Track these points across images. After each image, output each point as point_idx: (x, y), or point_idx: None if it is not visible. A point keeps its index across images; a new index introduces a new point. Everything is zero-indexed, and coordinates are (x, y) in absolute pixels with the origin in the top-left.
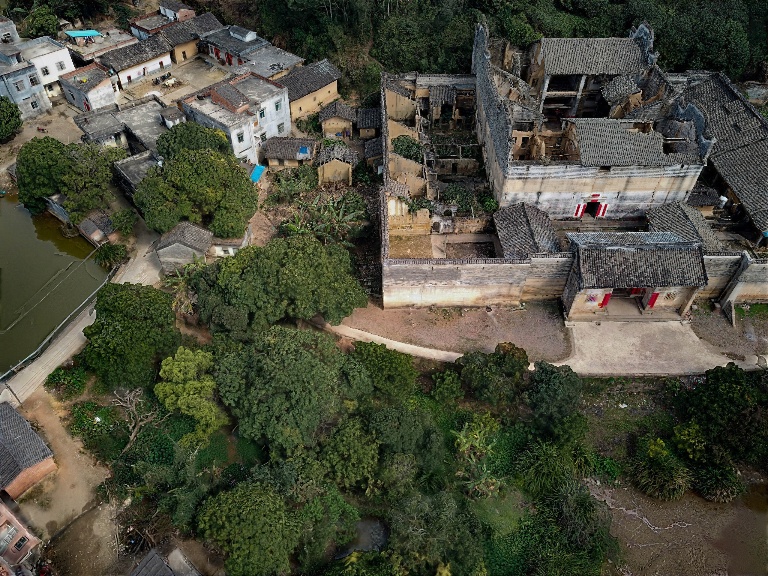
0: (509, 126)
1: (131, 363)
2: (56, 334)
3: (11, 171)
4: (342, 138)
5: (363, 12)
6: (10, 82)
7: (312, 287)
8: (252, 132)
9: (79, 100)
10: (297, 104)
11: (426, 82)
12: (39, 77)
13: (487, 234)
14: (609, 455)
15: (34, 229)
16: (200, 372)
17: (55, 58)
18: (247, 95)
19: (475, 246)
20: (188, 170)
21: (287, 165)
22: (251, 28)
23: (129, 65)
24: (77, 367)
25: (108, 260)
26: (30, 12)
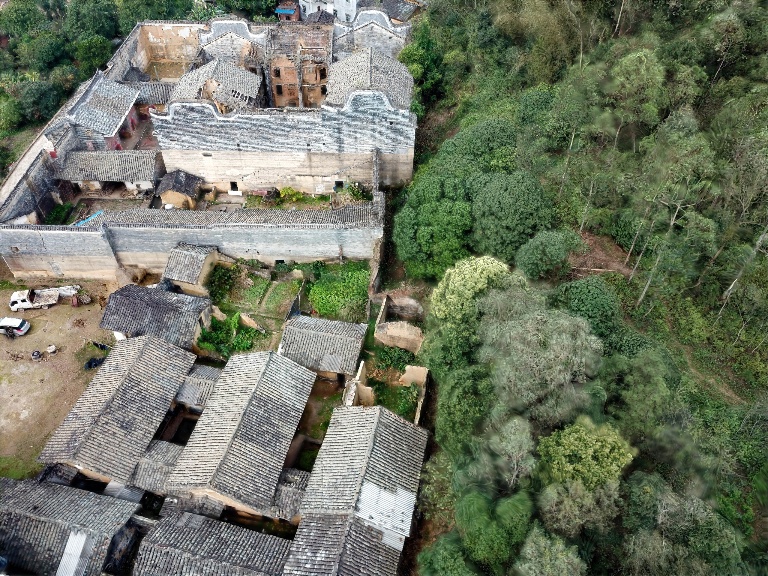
0: None
1: None
2: None
3: None
4: None
5: None
6: None
7: (128, 4)
8: None
9: None
10: None
11: None
12: None
13: None
14: (4, 140)
15: None
16: None
17: None
18: None
19: None
20: None
21: None
22: None
23: None
24: None
25: None
26: None
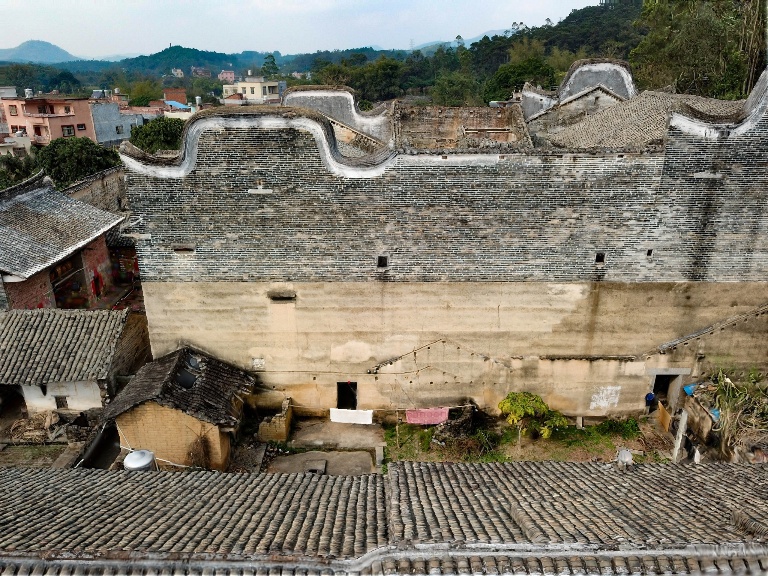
0: None
1: None
2: None
3: None
4: None
5: None
6: None
7: None
8: None
9: None
10: None
11: None
12: None
13: None
14: None
15: None
16: None
17: None
18: None
19: None
20: None
21: None
22: None
23: None
24: None
25: None
26: None
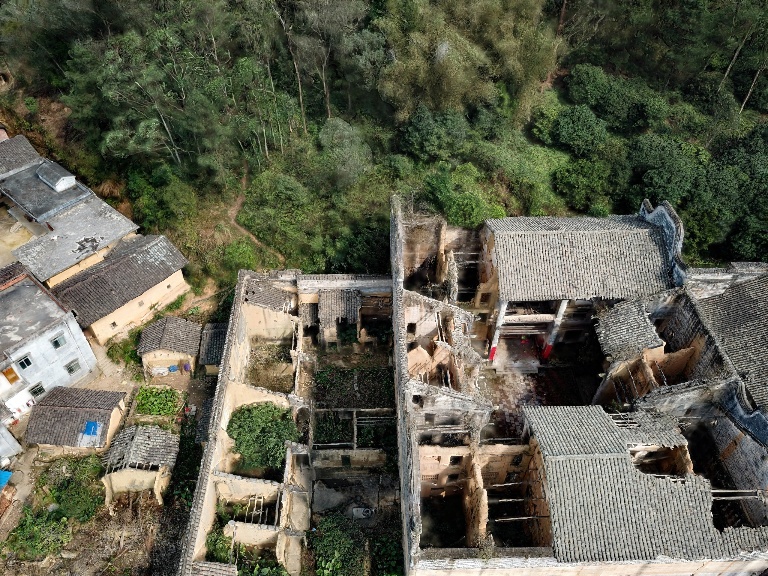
0: (411, 493)
1: None
2: None
3: None
4: (179, 374)
5: None
6: None
7: None
8: None
9: None
10: (105, 320)
11: (312, 285)
12: None
13: None
14: None
15: None
16: None
17: None
18: (1, 329)
19: None
20: None
21: (68, 447)
22: None
23: None
24: None
25: None
26: None
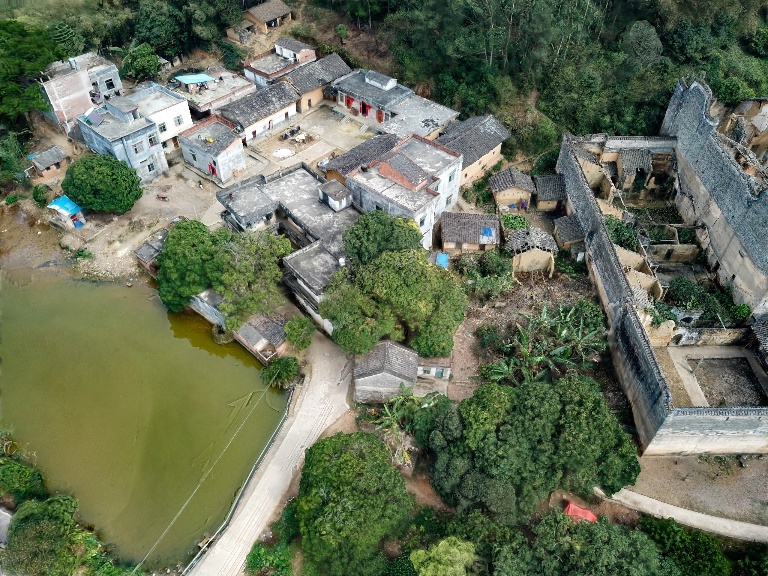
0: None
1: (358, 546)
2: (242, 491)
3: (140, 255)
4: (516, 210)
5: (537, 61)
6: (129, 144)
7: (597, 455)
8: (433, 213)
9: (202, 162)
10: (464, 171)
11: (617, 145)
12: (158, 136)
13: (735, 346)
14: None
15: (169, 325)
16: (467, 575)
17: (173, 112)
18: (418, 165)
19: (725, 363)
20: (396, 280)
21: (465, 248)
22: (384, 72)
23: (257, 119)
24: (278, 541)
25: (280, 380)
26: (129, 52)
